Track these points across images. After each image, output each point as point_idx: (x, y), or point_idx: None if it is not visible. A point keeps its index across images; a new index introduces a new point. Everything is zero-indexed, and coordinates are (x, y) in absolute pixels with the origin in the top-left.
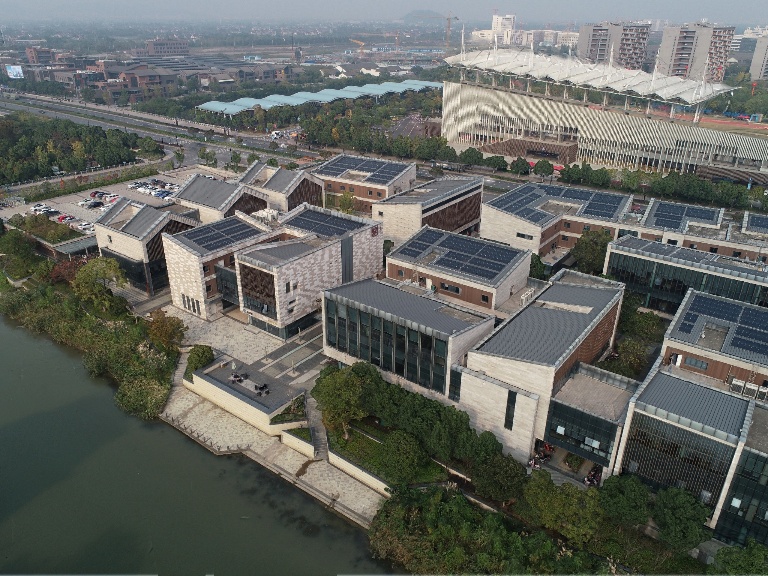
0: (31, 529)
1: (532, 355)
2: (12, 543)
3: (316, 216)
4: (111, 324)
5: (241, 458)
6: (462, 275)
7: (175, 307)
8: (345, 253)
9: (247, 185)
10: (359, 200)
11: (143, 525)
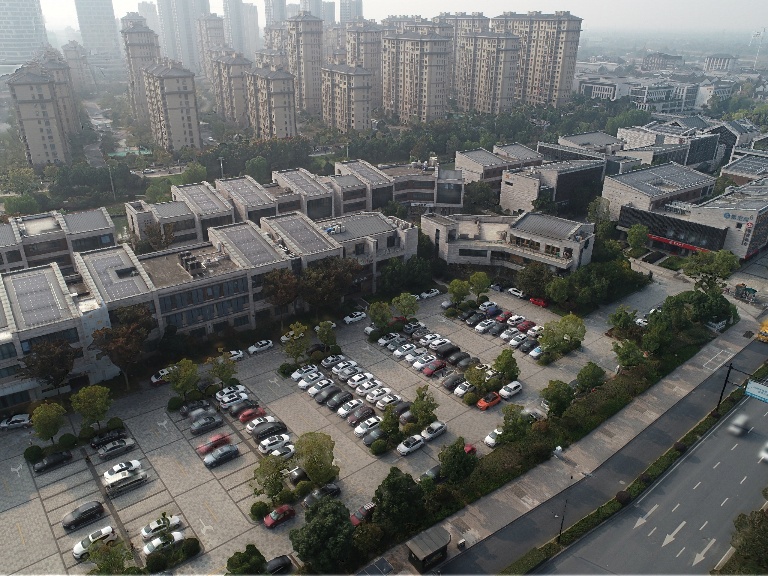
0: None
1: None
2: None
3: None
4: None
5: None
6: None
7: None
8: (658, 143)
9: None
10: None
11: None
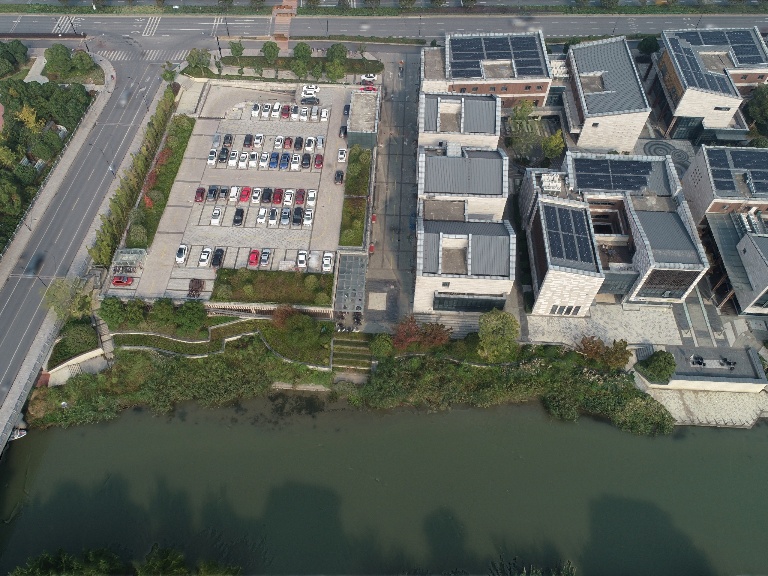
0: (738, 555)
1: None
2: (749, 571)
3: (594, 166)
4: (528, 367)
5: (765, 421)
6: None
7: (537, 316)
8: None
9: (438, 134)
10: (512, 97)
11: None
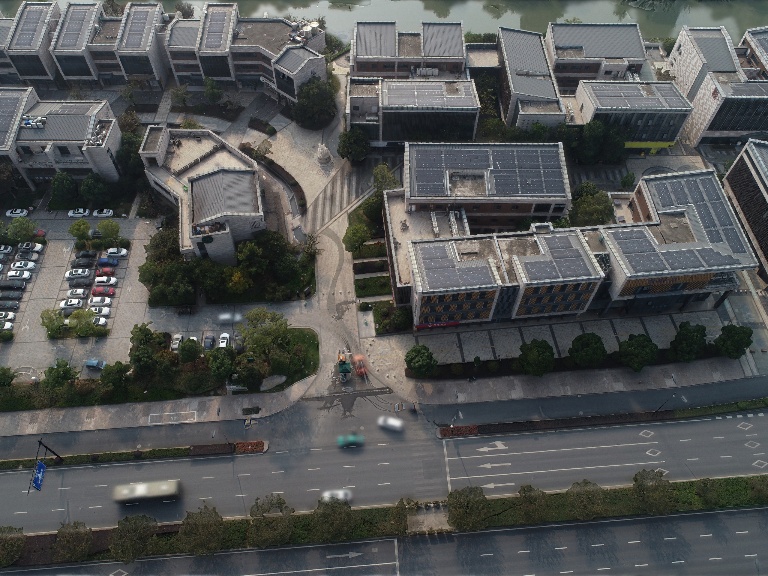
0: (613, 8)
1: (514, 35)
2: (609, 3)
3: None
4: None
5: None
6: (610, 84)
7: None
8: (700, 77)
9: None
10: None
11: (585, 17)
